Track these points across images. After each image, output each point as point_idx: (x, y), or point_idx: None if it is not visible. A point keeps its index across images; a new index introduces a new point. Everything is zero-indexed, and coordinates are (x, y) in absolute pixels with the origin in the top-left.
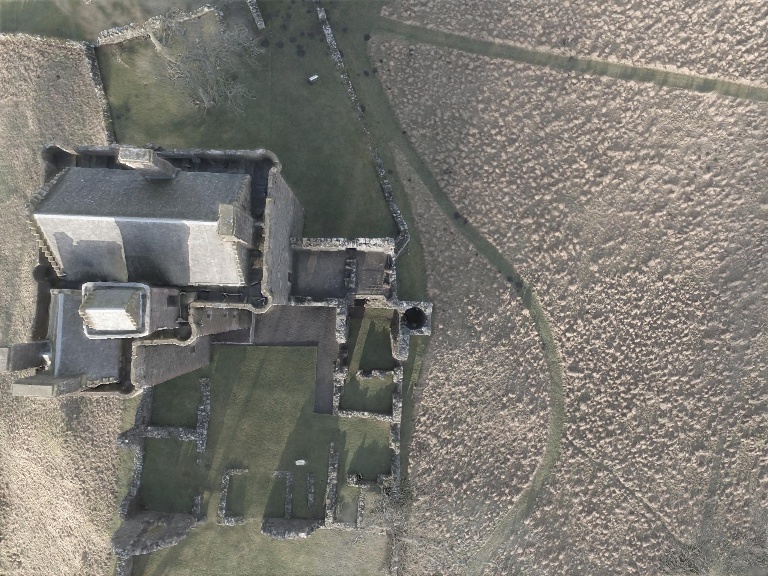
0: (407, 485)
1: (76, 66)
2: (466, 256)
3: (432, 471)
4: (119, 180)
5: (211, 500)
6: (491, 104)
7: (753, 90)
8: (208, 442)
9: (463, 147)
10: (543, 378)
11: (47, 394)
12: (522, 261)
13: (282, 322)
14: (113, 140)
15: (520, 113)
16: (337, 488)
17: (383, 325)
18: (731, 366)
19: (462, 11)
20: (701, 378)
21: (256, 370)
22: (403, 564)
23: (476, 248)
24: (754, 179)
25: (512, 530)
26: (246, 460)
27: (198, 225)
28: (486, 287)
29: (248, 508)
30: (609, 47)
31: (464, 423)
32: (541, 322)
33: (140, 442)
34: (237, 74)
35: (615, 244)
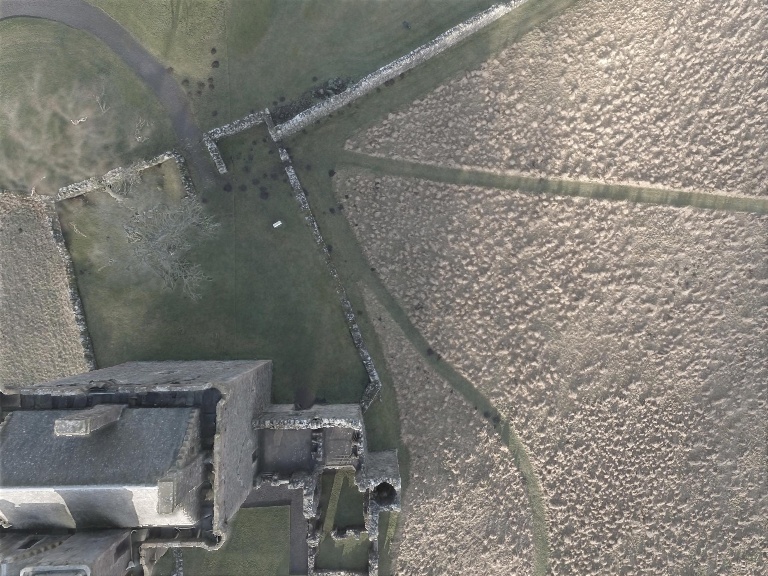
0: None
1: (38, 219)
2: (440, 395)
3: None
4: None
5: None
6: (461, 233)
7: (730, 200)
8: None
9: (434, 281)
10: (525, 514)
11: None
12: (498, 395)
13: None
14: (77, 298)
15: (491, 241)
16: None
17: None
18: (719, 487)
19: (428, 139)
20: (688, 502)
21: (229, 533)
22: None
23: (451, 385)
24: (735, 292)
25: None
26: None
27: (140, 489)
28: (462, 426)
29: None
30: (580, 166)
31: (444, 571)
32: (520, 456)
33: None
34: None
35: (594, 369)
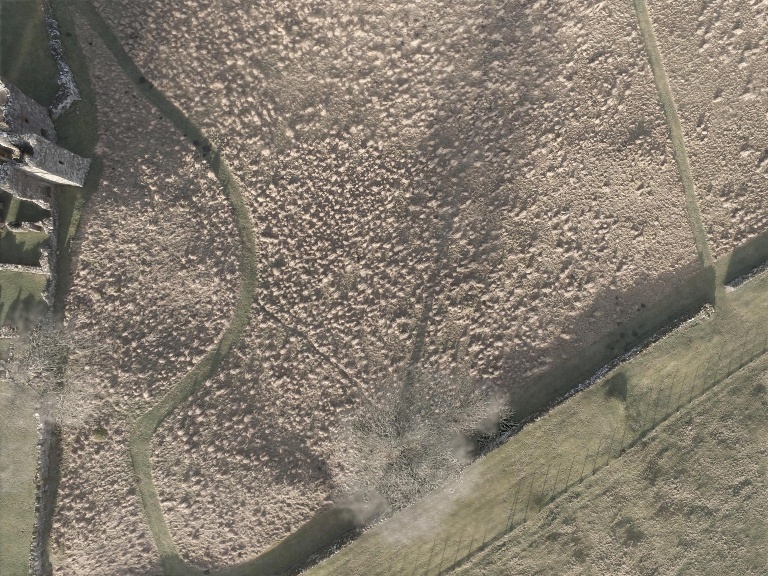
0: (63, 338)
1: None
2: (148, 119)
3: (94, 326)
4: None
5: None
6: None
7: None
8: None
9: (149, 11)
10: (232, 243)
11: None
12: (211, 126)
13: None
14: None
15: None
16: None
17: None
18: (439, 234)
19: None
20: (405, 246)
21: None
22: (61, 418)
23: (161, 112)
24: (466, 46)
25: (192, 391)
26: None
27: None
28: (166, 149)
29: None
30: None
31: (135, 282)
32: (231, 187)
33: None
34: None
35: (315, 111)
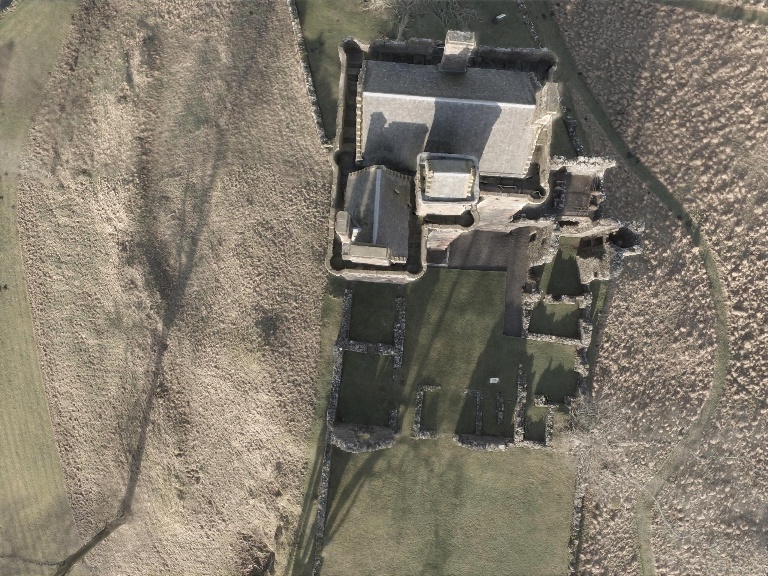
0: (591, 408)
1: (269, 2)
2: (640, 194)
3: (613, 397)
4: (417, 71)
5: (406, 414)
6: (661, 49)
7: None
8: (404, 359)
9: (636, 89)
10: (710, 315)
11: (382, 255)
12: (691, 201)
13: (474, 247)
14: (309, 71)
15: (689, 59)
16: (525, 408)
17: (570, 253)
18: None
19: None
20: None
21: (449, 292)
22: None
23: (648, 187)
24: None
25: (682, 460)
26: (439, 378)
27: (511, 107)
28: (660, 224)
29: (440, 424)
30: None
31: (640, 353)
32: (708, 261)
33: (342, 355)
34: (424, 13)
35: None
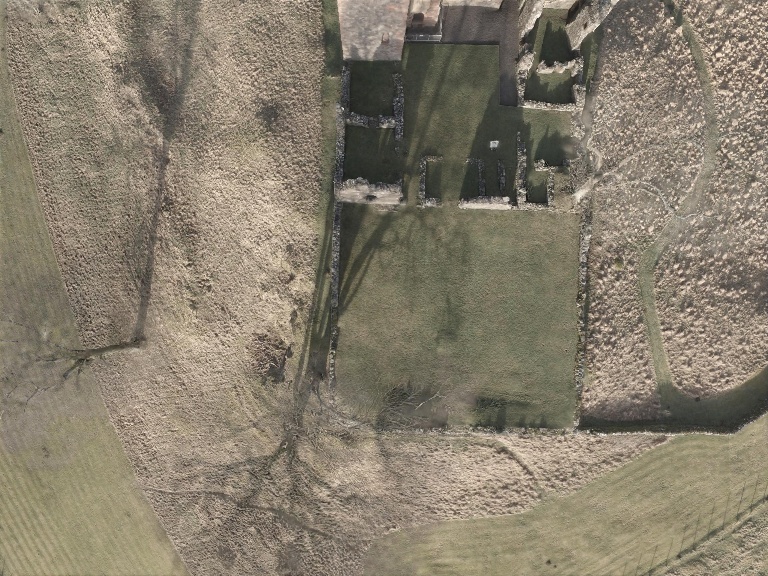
0: (590, 171)
1: None
2: None
3: (610, 162)
4: None
5: (411, 184)
6: None
7: None
8: (404, 131)
9: None
10: (697, 94)
11: None
12: None
13: (465, 22)
14: None
15: None
16: (526, 173)
17: (559, 25)
18: None
19: None
20: None
21: (444, 67)
22: None
23: None
24: None
25: (679, 229)
26: (440, 149)
27: None
28: (643, 4)
29: (445, 192)
30: None
31: (633, 124)
32: (692, 43)
33: (344, 127)
34: None
35: None
